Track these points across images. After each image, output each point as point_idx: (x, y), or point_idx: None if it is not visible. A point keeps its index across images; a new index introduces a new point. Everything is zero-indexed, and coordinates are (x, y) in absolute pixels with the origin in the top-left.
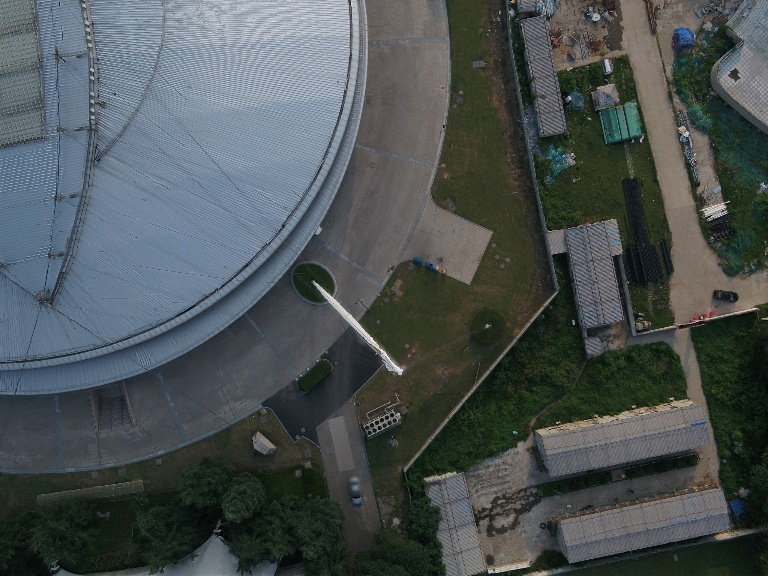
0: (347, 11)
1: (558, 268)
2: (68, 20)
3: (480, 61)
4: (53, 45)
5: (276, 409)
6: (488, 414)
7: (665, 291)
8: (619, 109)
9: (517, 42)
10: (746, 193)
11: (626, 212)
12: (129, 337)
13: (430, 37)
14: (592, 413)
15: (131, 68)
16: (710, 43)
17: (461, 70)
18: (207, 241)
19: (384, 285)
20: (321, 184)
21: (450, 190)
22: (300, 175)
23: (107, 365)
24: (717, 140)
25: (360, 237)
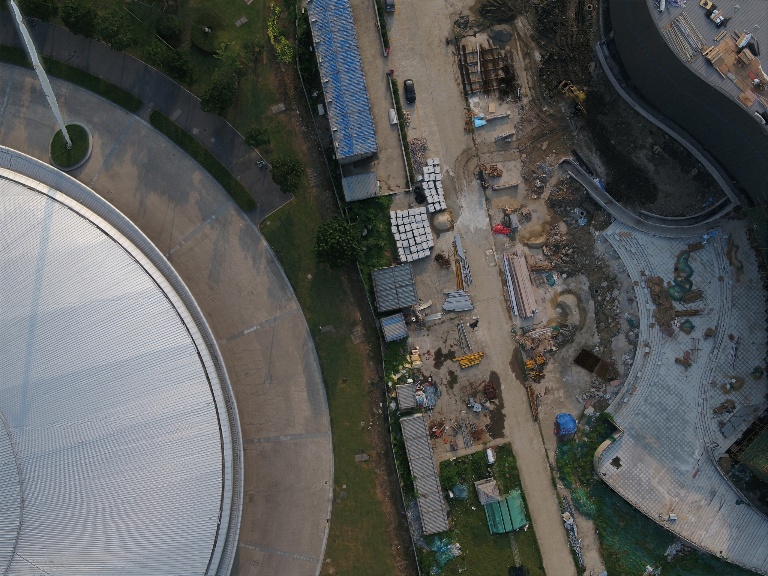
0: (219, 443)
1: None
2: None
3: (363, 454)
4: None
5: None
6: None
7: None
8: (502, 502)
9: (399, 435)
10: None
11: None
12: None
13: (312, 432)
14: None
15: None
16: (592, 427)
17: (344, 464)
18: None
19: None
20: None
21: None
22: None
23: None
24: (602, 525)
25: None
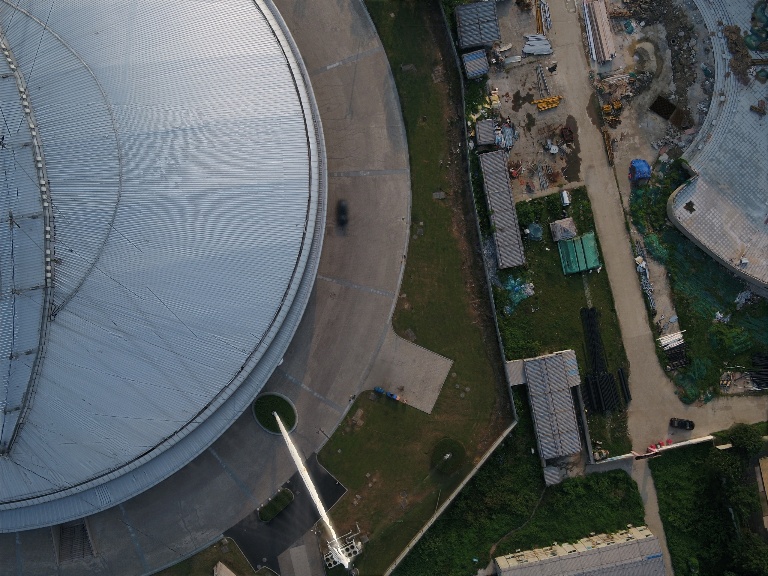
0: (306, 154)
1: (517, 398)
2: (23, 182)
3: (440, 192)
4: (8, 207)
5: (237, 539)
6: (448, 542)
7: (623, 419)
8: (577, 241)
9: (477, 174)
10: (702, 322)
11: (584, 341)
12: (87, 481)
13: (391, 169)
14: (551, 540)
15: (88, 225)
16: (666, 174)
17: (421, 201)
18: (165, 387)
19: (345, 414)
20: (280, 325)
21: (411, 320)
22: (259, 318)
23: (66, 503)
24: (673, 270)
25: (321, 367)
